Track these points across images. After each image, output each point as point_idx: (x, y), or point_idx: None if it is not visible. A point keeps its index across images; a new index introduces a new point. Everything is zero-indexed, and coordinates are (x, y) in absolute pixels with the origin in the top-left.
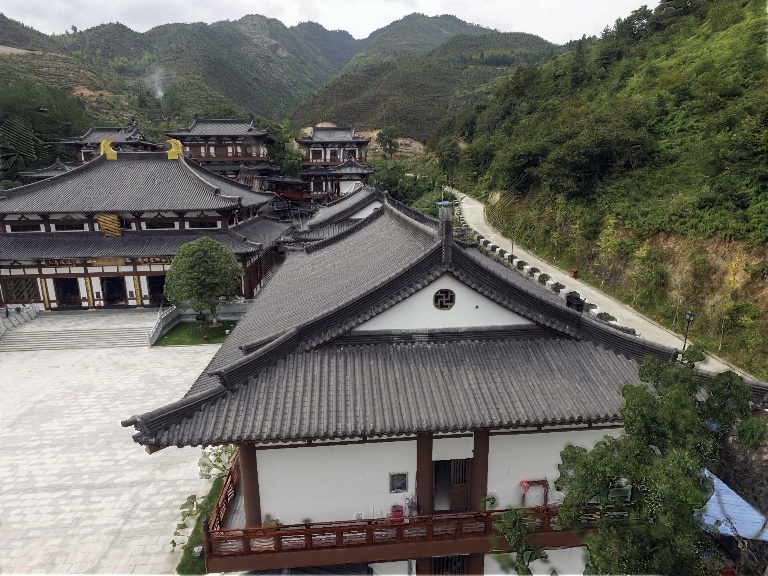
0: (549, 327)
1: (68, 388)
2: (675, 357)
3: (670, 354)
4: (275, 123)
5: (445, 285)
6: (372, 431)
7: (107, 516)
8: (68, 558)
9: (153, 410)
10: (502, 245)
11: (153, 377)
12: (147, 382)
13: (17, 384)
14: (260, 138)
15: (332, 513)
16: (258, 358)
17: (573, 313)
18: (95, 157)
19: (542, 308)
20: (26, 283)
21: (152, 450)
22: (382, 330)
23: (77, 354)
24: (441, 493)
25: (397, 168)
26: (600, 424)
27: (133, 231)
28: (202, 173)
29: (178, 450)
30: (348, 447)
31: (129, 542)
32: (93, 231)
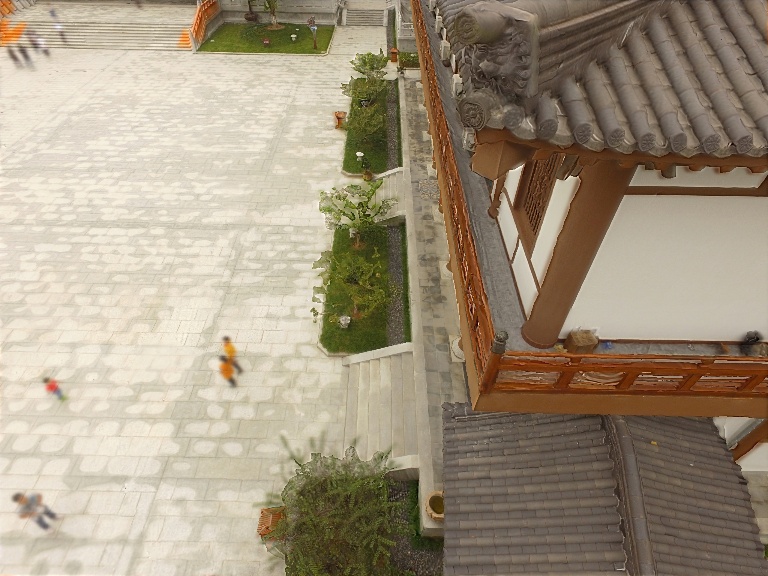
0: None
1: (105, 98)
2: None
3: None
4: None
5: None
6: None
7: (207, 264)
8: (173, 313)
9: (224, 134)
10: None
11: (211, 91)
12: (205, 97)
13: (39, 89)
14: None
15: (703, 327)
16: None
17: None
18: None
19: None
20: None
21: (503, 165)
22: None
23: (103, 56)
24: None
25: None
26: None
27: None
28: None
29: (273, 188)
30: None
31: (245, 300)
32: None
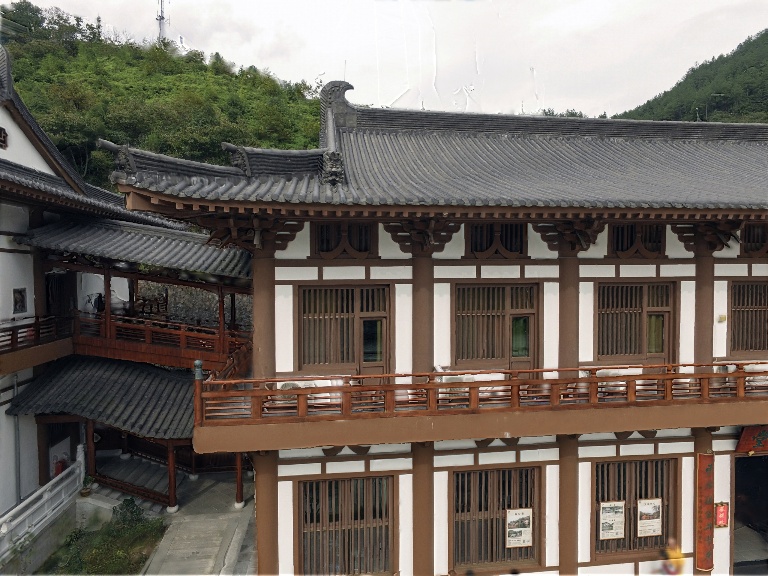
0: None
1: None
2: None
3: None
4: None
5: None
6: None
7: None
8: None
9: None
10: None
11: None
12: None
13: None
14: None
15: None
16: None
17: None
18: None
19: None
20: None
21: None
22: None
23: None
24: None
25: None
26: None
27: None
28: None
29: None
30: None
31: None
32: None
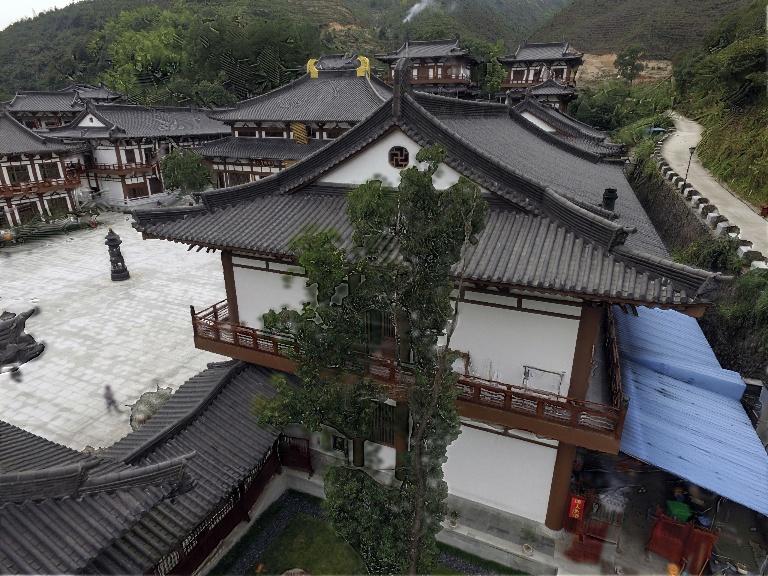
0: (501, 196)
1: None
2: (618, 236)
3: (613, 231)
4: (486, 44)
5: (399, 142)
6: (277, 250)
7: None
8: (184, 347)
9: None
10: (690, 175)
11: None
12: None
13: None
14: (461, 59)
15: None
16: (236, 191)
17: (536, 184)
18: (302, 75)
19: (498, 174)
20: (243, 178)
21: (144, 237)
22: (343, 183)
23: None
24: (376, 343)
25: (621, 92)
26: (531, 307)
27: (316, 140)
28: (385, 90)
29: None
30: (295, 278)
31: None
32: (289, 138)
